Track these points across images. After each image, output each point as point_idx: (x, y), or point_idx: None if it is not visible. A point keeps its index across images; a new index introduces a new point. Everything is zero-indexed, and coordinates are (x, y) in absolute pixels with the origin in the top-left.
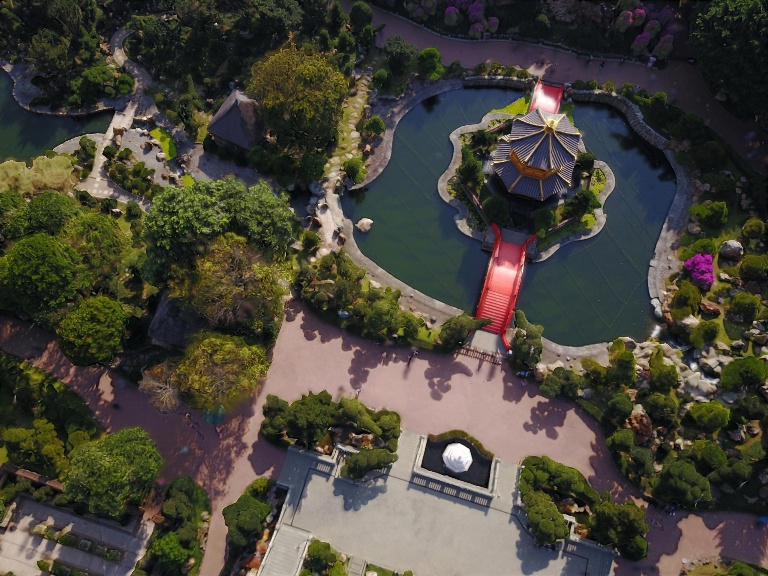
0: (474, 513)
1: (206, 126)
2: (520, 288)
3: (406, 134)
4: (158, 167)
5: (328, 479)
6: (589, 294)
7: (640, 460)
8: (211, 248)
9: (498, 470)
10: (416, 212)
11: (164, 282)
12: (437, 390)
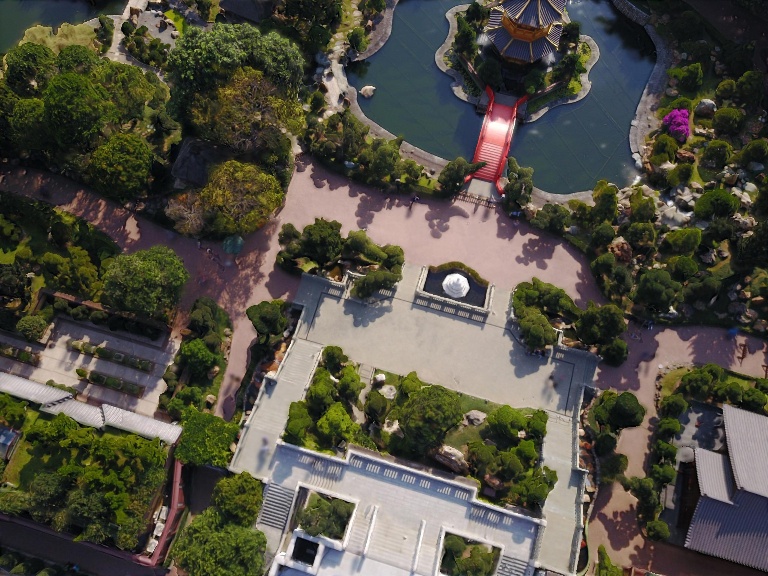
0: (471, 328)
1: (217, 7)
2: (512, 145)
3: (405, 13)
4: (173, 43)
5: (339, 301)
6: (575, 151)
7: (621, 274)
8: (231, 77)
9: (493, 292)
10: (415, 82)
11: (187, 116)
12: (437, 230)
